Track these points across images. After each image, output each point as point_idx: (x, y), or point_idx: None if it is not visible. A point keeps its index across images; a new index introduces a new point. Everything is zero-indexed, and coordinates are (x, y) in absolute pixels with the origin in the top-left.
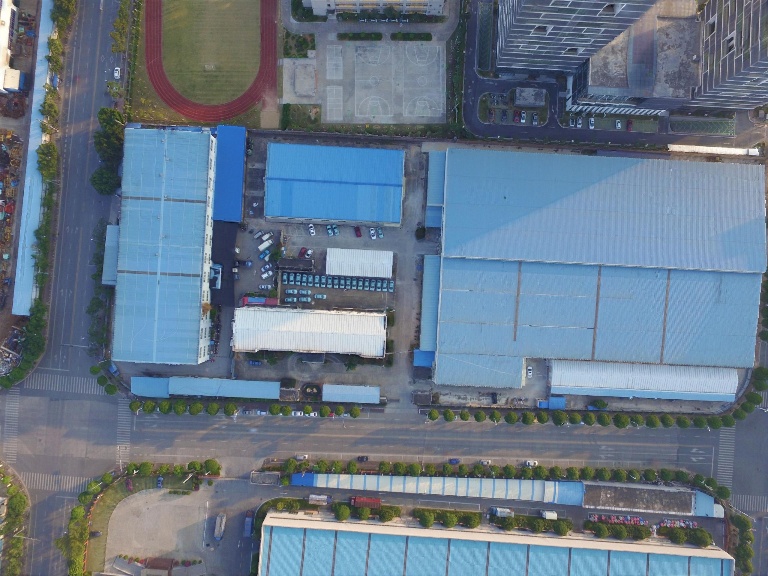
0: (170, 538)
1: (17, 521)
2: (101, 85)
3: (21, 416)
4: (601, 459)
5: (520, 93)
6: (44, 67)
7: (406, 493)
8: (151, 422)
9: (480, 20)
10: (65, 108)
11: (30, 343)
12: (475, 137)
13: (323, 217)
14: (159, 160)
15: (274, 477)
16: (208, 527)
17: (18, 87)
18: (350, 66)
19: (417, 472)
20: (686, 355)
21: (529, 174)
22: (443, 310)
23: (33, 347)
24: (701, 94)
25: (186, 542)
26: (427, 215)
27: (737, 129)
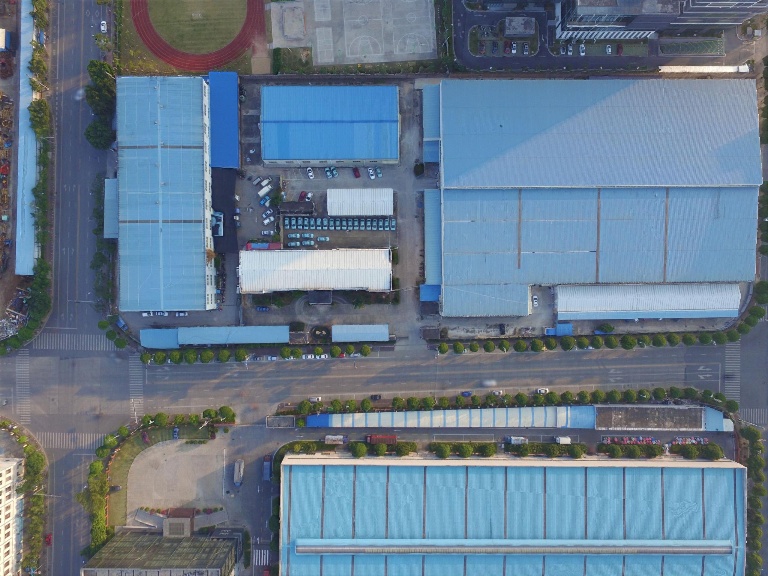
0: (190, 488)
1: (36, 479)
2: (88, 40)
3: (32, 377)
4: (610, 383)
5: (509, 23)
6: (29, 24)
7: (421, 428)
8: (163, 374)
9: None
10: (53, 65)
11: (36, 301)
12: (467, 70)
13: (321, 157)
14: (153, 107)
15: (289, 420)
16: (227, 474)
17: (4, 46)
18: (338, 6)
19: (430, 405)
20: (688, 272)
21: (523, 101)
22: (446, 242)
23: (39, 305)
24: (690, 7)
25: (206, 491)
26: (424, 150)
27: (726, 48)
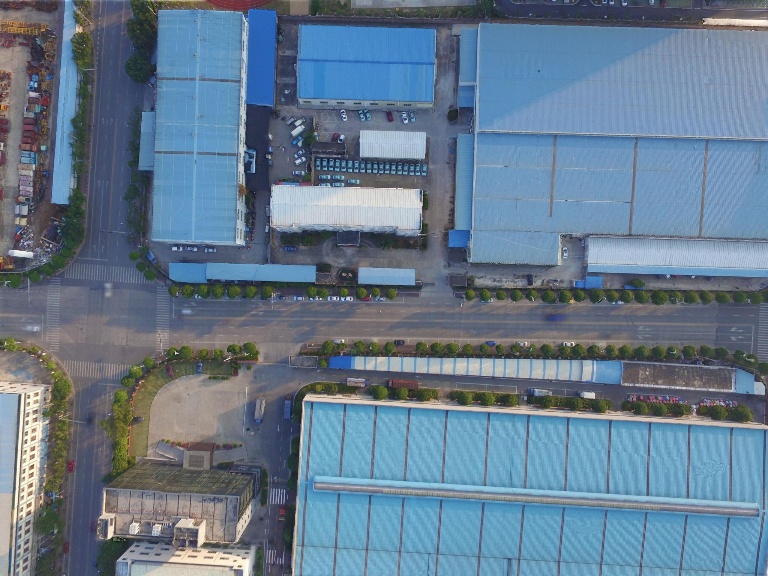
0: (211, 423)
1: (62, 405)
2: None
3: (62, 306)
4: (639, 339)
5: None
6: None
7: (443, 375)
8: (189, 309)
9: None
10: (97, 1)
11: (70, 228)
12: (506, 17)
13: (356, 98)
14: (193, 40)
15: (312, 360)
16: (248, 412)
17: None
18: None
19: (455, 350)
20: (725, 228)
21: (563, 47)
22: (478, 186)
23: (73, 232)
24: None
25: (226, 427)
26: (459, 95)
27: None
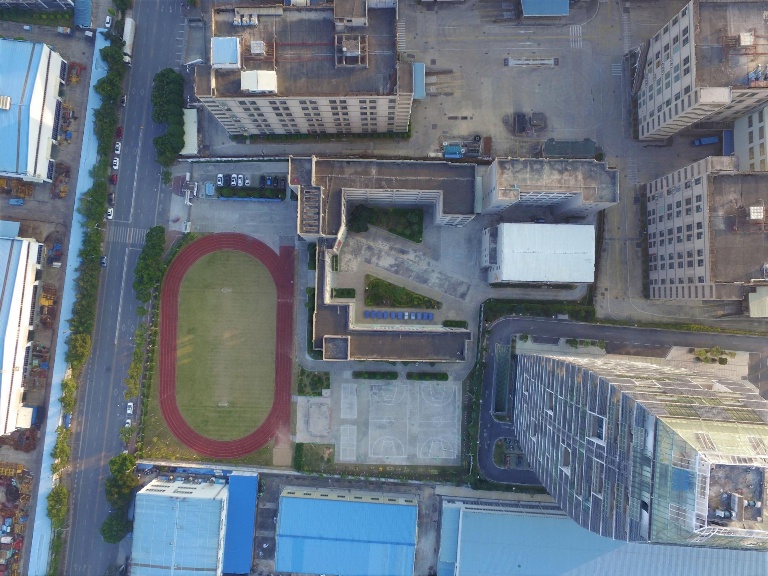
0: None
1: None
2: (113, 419)
3: None
4: None
5: None
6: (57, 408)
7: None
8: None
9: (497, 363)
10: (77, 442)
11: None
12: (490, 483)
13: (334, 574)
14: (170, 528)
15: None
16: None
17: (30, 425)
18: (365, 405)
19: None
20: None
21: (544, 541)
22: None
23: None
24: None
25: None
26: (439, 567)
27: None
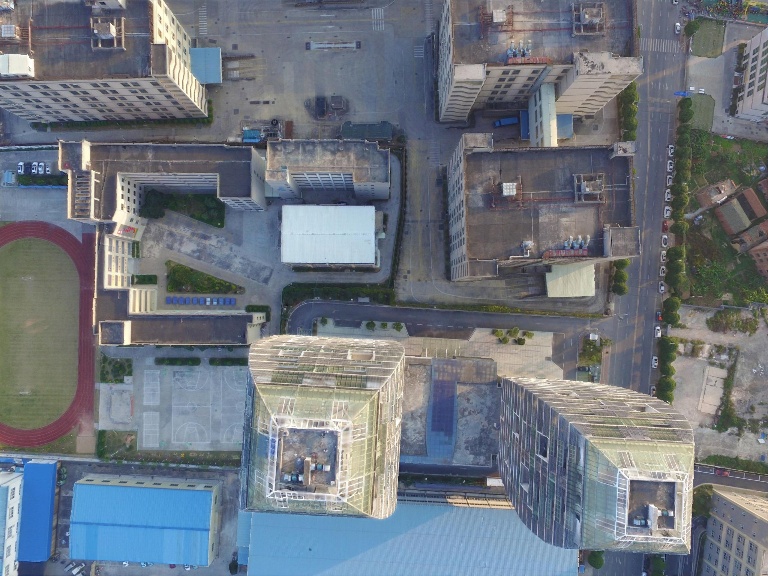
0: None
1: None
2: None
3: None
4: None
5: None
6: None
7: None
8: None
9: None
10: None
11: None
12: None
13: (129, 560)
14: None
15: None
16: None
17: None
18: (167, 391)
19: None
20: None
21: (336, 524)
22: None
23: None
24: None
25: None
26: (239, 552)
27: None
